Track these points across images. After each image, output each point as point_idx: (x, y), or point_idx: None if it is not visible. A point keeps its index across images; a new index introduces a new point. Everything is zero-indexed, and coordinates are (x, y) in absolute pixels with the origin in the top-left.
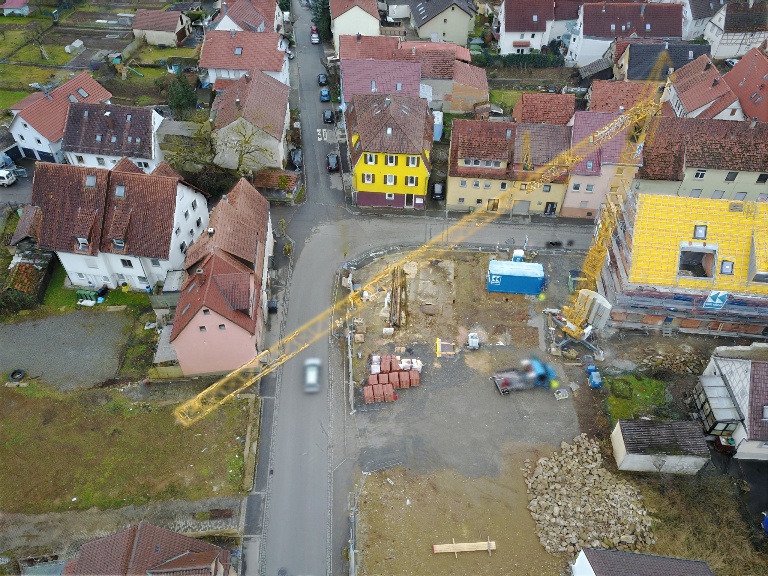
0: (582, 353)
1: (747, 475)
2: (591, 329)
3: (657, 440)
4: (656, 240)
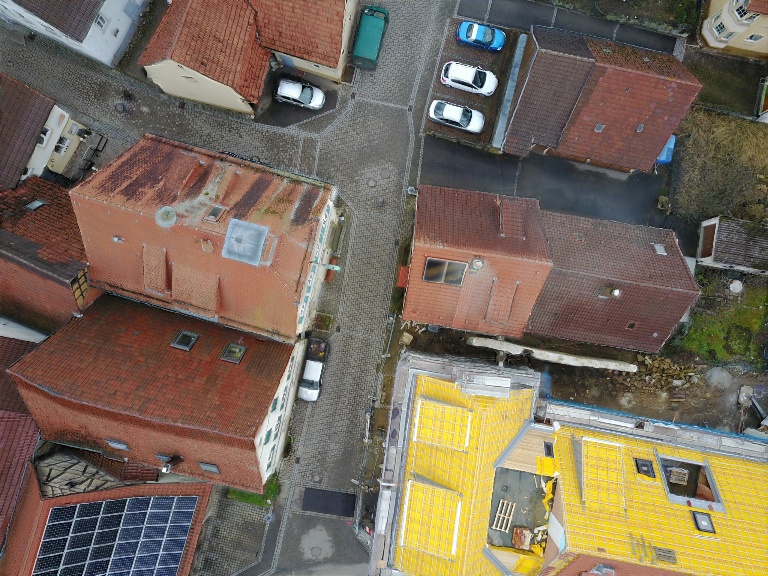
0: (764, 401)
1: (645, 218)
2: (761, 429)
3: (767, 243)
4: (762, 518)
